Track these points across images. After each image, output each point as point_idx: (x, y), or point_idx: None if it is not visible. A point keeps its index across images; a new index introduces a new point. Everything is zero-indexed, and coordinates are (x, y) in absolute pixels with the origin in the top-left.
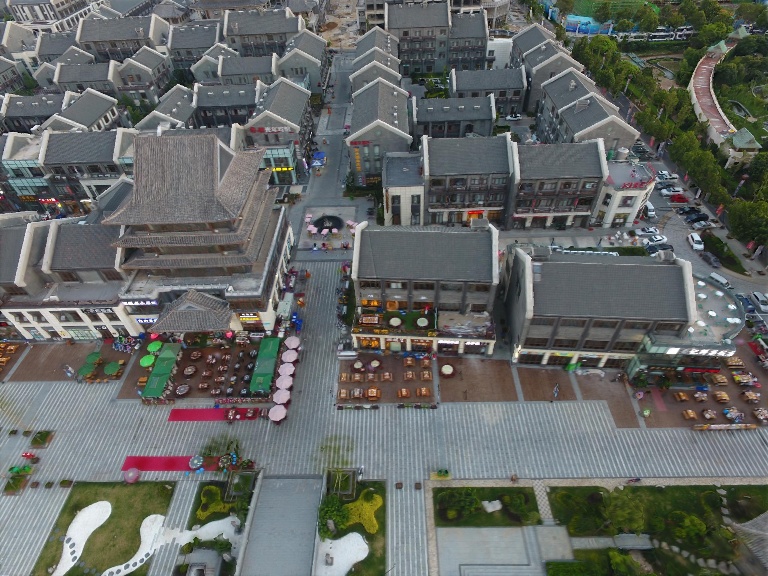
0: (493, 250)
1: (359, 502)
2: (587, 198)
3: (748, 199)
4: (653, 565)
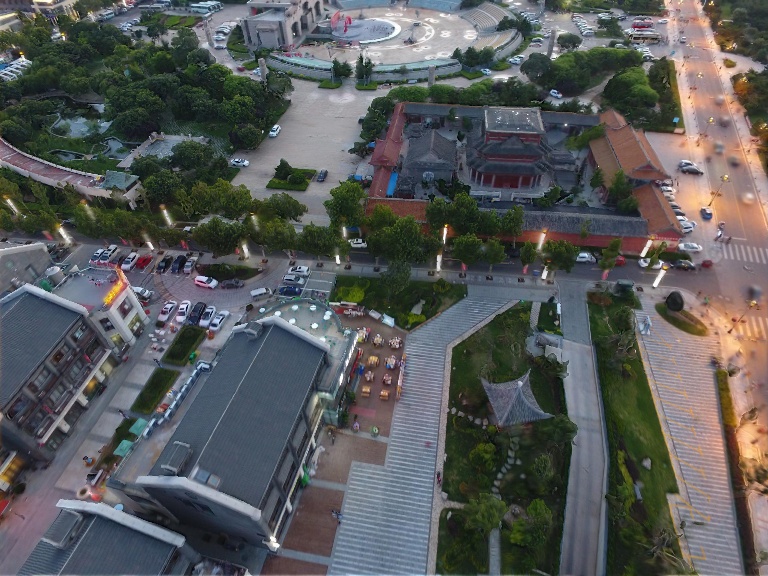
0: (129, 526)
1: None
2: (90, 343)
3: (182, 219)
4: (512, 502)
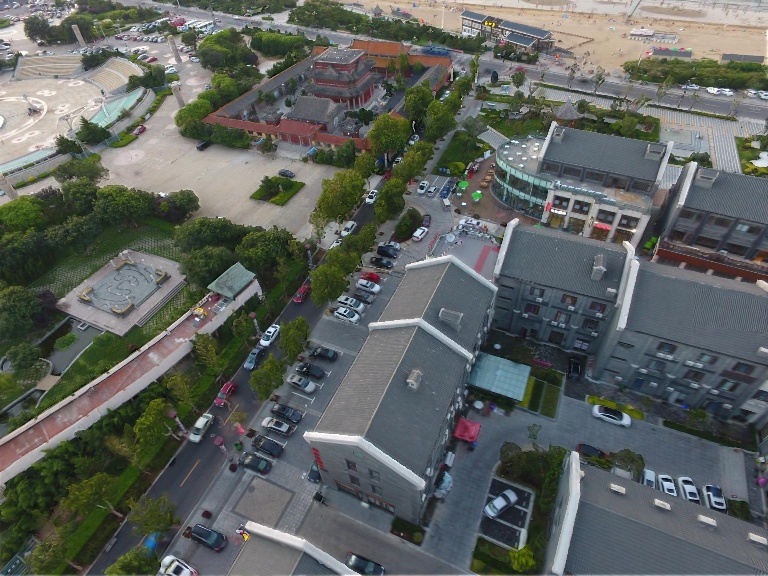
0: None
1: (760, 170)
2: None
3: None
4: None
